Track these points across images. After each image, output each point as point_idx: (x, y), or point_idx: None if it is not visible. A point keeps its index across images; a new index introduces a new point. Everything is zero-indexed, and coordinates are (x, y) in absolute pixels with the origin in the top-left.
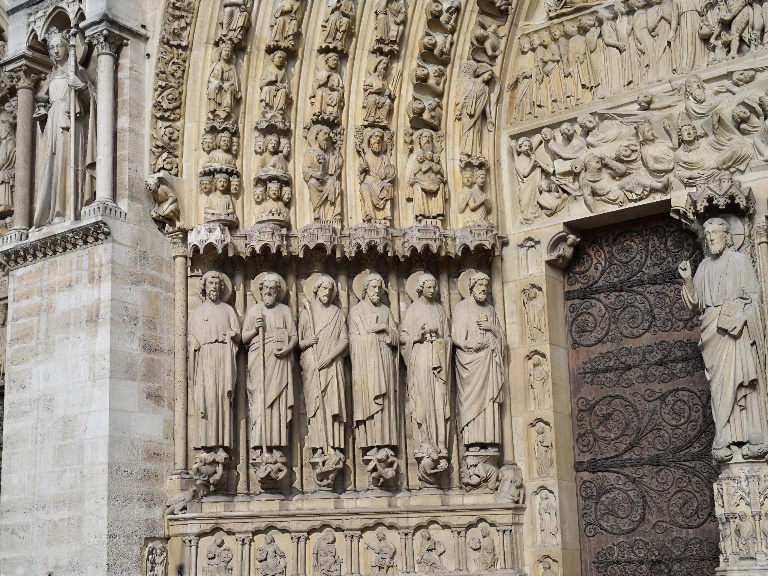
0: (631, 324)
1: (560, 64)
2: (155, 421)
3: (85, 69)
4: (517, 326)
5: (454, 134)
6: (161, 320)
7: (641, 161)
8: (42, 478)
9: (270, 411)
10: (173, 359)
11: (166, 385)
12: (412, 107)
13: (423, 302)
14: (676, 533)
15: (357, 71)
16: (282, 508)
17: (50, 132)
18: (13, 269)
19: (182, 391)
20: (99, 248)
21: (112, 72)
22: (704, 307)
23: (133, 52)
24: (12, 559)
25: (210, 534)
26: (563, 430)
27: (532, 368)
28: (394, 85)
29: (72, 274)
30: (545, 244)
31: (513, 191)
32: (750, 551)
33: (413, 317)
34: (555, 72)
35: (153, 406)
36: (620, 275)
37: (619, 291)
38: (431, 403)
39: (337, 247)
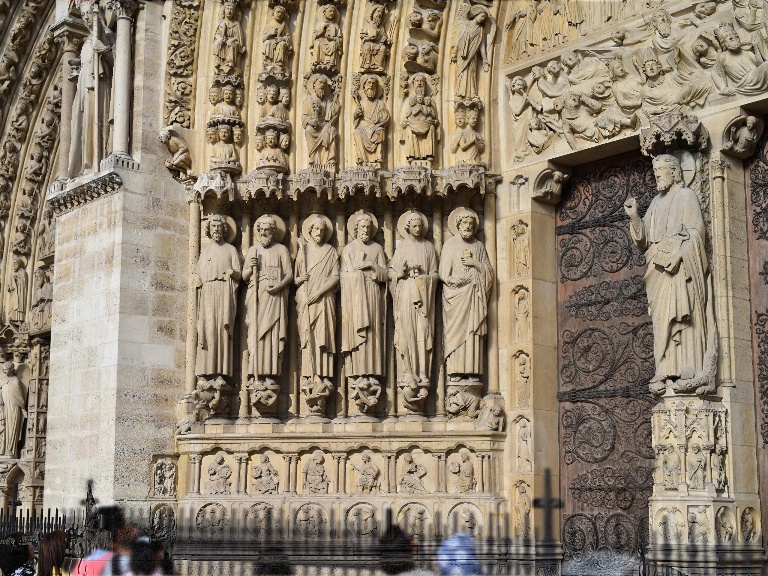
0: (611, 259)
1: (551, 2)
2: (166, 351)
3: (112, 32)
4: (506, 261)
5: (450, 76)
6: (174, 260)
7: (614, 97)
8: (74, 401)
9: (262, 343)
10: (186, 295)
11: (178, 319)
12: (406, 52)
13: (411, 240)
14: (640, 463)
15: (355, 20)
16: (275, 431)
17: (78, 92)
18: (59, 216)
19: (192, 324)
20: (115, 197)
21: (128, 35)
22: (649, 243)
23: (149, 15)
24: (53, 470)
25: (212, 453)
26: (545, 362)
27: (518, 302)
28: (391, 32)
29: (97, 220)
30: (532, 181)
31: (509, 129)
32: (674, 482)
33: (400, 254)
34: (546, 10)
35: (164, 338)
36: (604, 210)
37: (602, 226)
38: (411, 336)
39: (328, 190)
